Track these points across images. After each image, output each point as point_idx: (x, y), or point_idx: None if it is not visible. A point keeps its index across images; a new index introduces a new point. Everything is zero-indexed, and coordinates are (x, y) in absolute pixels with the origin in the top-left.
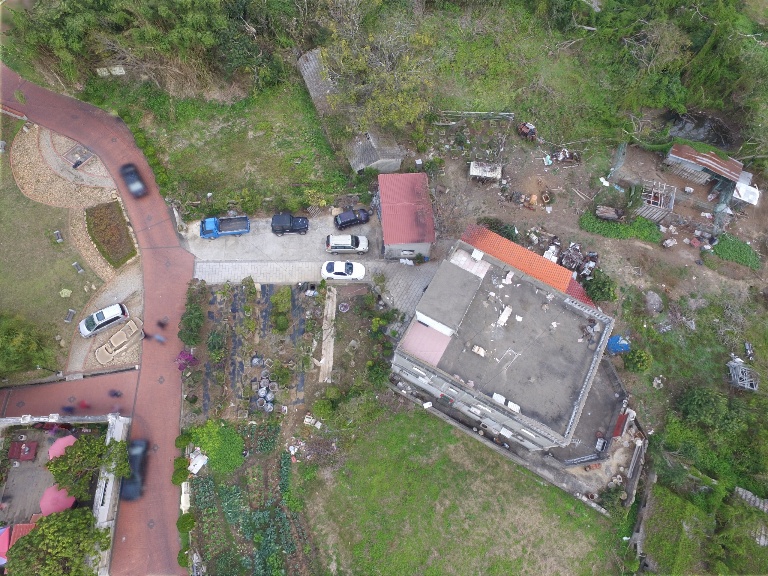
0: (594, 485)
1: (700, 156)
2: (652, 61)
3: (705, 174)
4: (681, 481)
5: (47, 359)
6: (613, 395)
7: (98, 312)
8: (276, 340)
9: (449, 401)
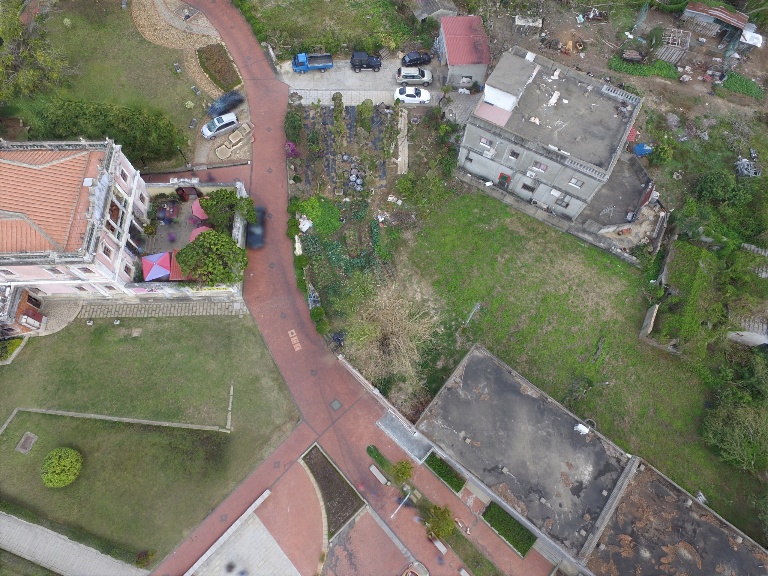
0: (626, 244)
1: (711, 9)
2: None
3: (716, 25)
4: (697, 235)
5: (178, 153)
6: (640, 186)
7: (218, 117)
8: (364, 135)
9: (506, 182)
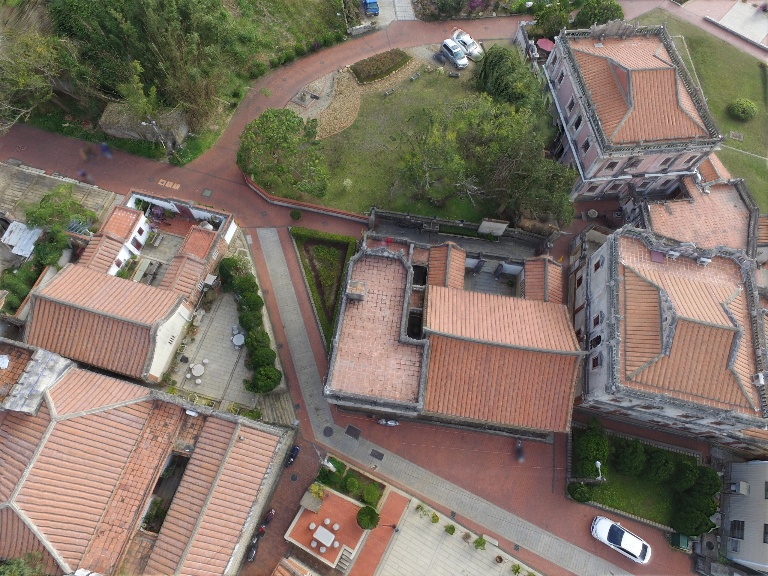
0: None
1: None
2: None
3: None
4: None
5: None
6: None
7: (452, 49)
8: None
9: None
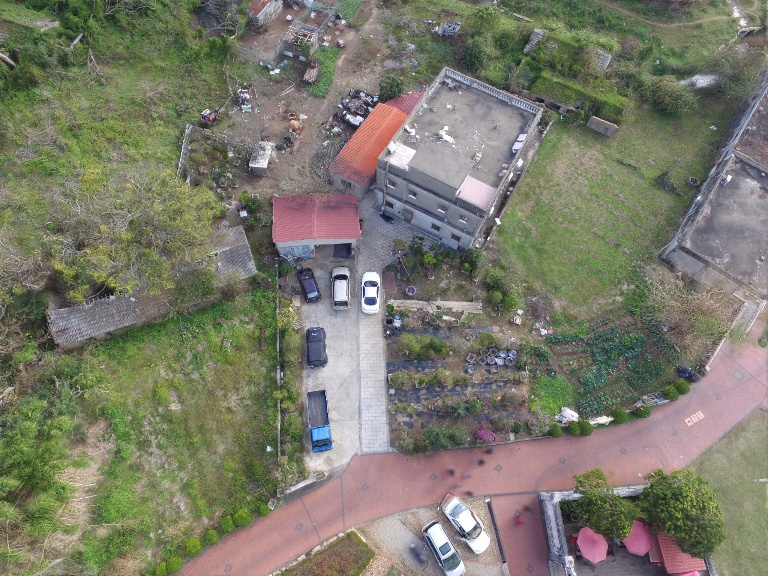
0: None
1: None
2: (142, 1)
3: (279, 1)
4: None
5: None
6: None
7: (440, 554)
8: None
9: None
